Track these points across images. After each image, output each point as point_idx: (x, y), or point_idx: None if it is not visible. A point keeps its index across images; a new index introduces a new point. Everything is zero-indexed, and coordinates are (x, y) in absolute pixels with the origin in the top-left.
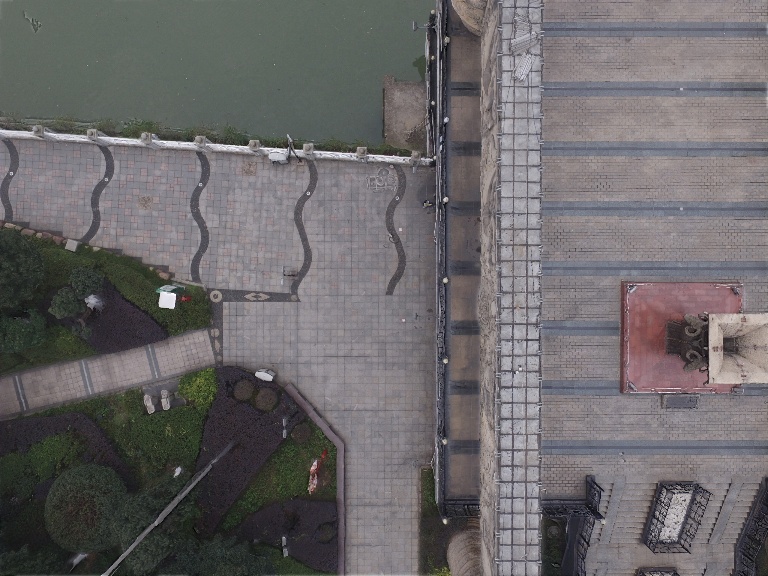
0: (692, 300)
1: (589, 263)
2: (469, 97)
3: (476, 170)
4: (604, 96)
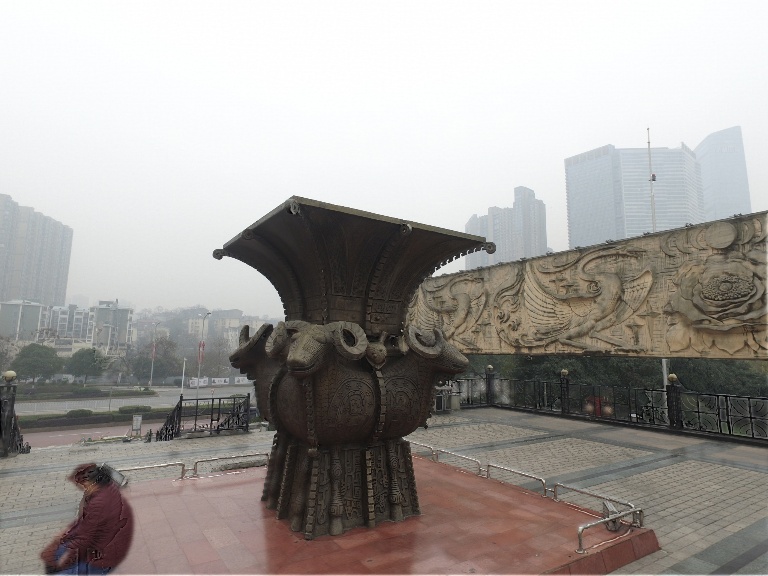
0: (390, 571)
1: None
2: None
3: None
4: None
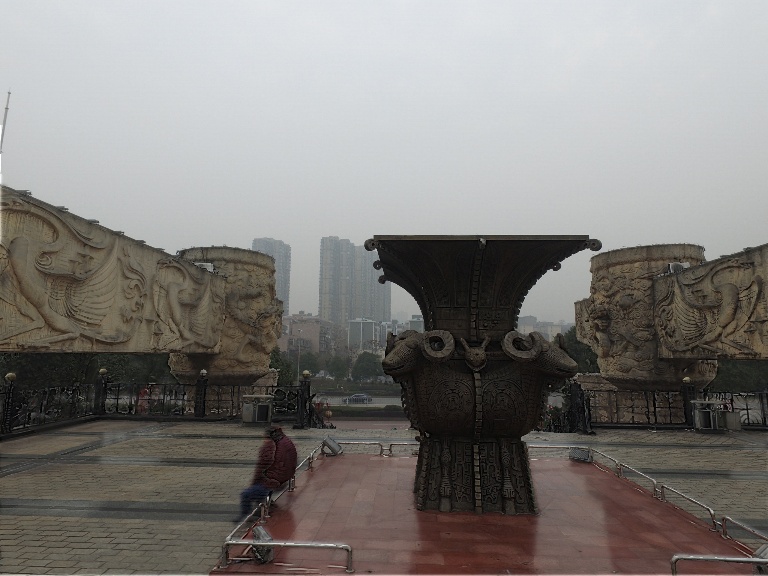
0: (455, 544)
1: None
2: None
3: None
4: None
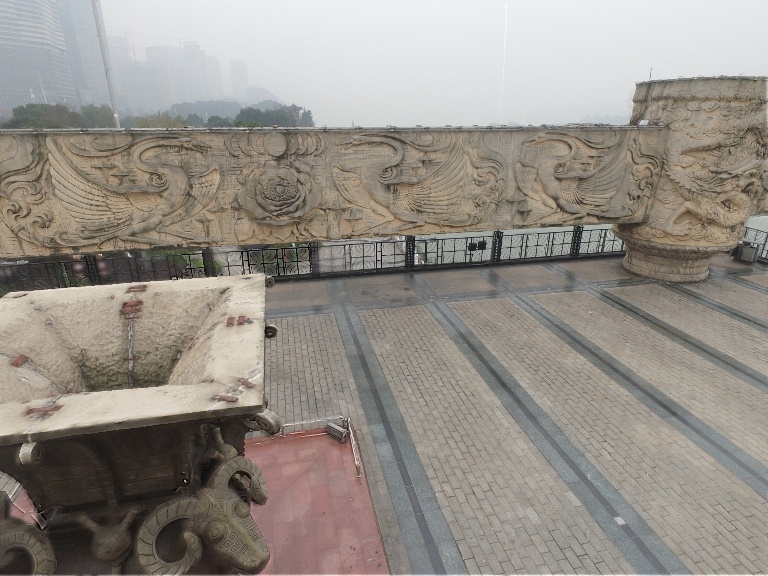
0: None
1: (382, 380)
2: (552, 272)
3: (469, 282)
4: (701, 356)
